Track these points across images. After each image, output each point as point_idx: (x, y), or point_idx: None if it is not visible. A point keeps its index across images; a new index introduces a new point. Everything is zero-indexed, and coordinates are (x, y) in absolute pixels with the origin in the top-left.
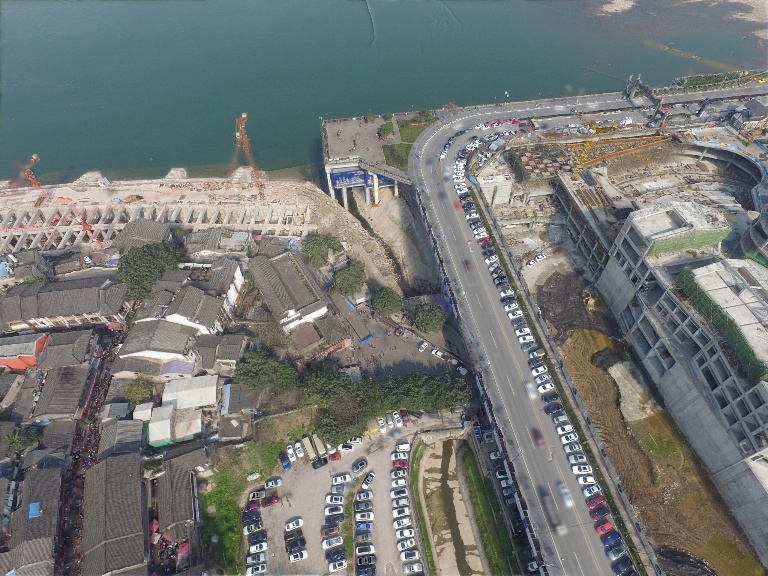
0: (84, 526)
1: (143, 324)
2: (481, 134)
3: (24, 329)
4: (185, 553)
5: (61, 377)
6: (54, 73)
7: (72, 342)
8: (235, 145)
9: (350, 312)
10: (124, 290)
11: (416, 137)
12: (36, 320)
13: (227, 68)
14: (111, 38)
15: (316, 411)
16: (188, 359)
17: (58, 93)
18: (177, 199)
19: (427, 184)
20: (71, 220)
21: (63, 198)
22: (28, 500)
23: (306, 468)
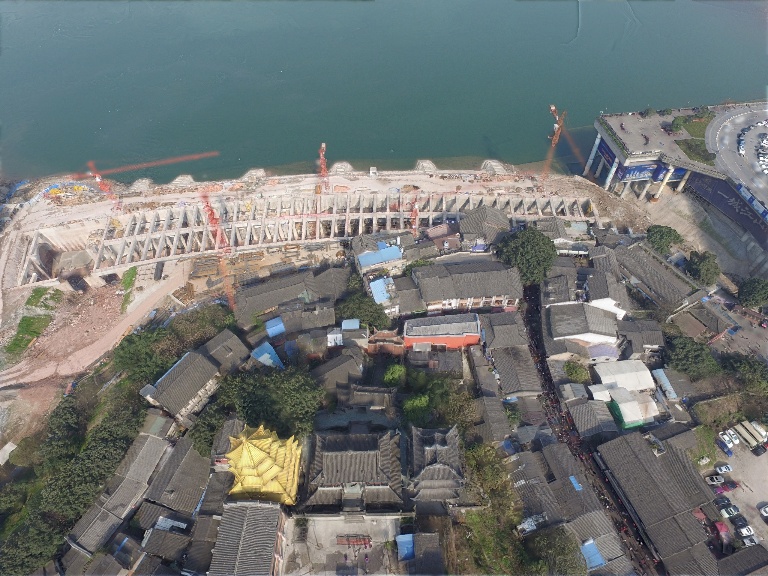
0: (633, 500)
1: (562, 307)
2: (767, 131)
3: (434, 309)
4: (726, 531)
5: (513, 356)
6: (254, 66)
7: (514, 322)
8: (470, 139)
9: (704, 303)
10: (518, 274)
11: (704, 133)
12: (449, 301)
13: (422, 64)
14: (291, 34)
15: (740, 399)
16: (616, 343)
17: (266, 86)
18: (454, 190)
19: (741, 179)
20: (344, 208)
21: (342, 186)
22: (565, 473)
23: (747, 455)
